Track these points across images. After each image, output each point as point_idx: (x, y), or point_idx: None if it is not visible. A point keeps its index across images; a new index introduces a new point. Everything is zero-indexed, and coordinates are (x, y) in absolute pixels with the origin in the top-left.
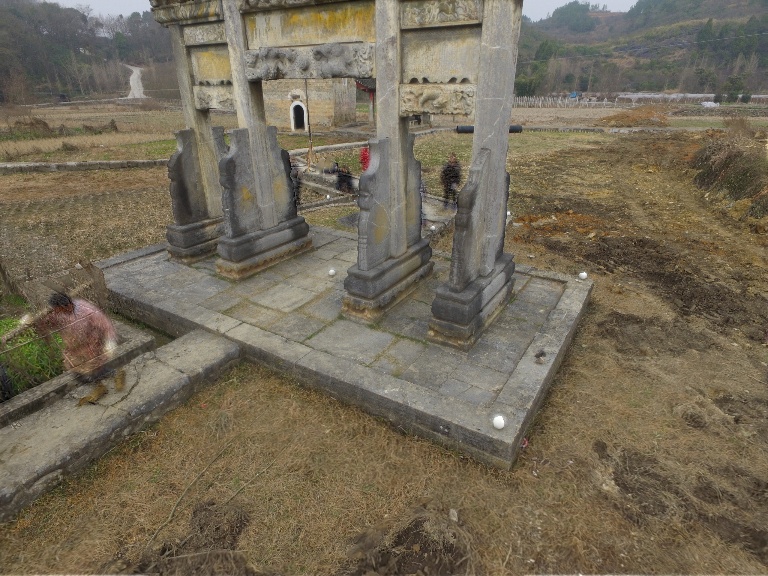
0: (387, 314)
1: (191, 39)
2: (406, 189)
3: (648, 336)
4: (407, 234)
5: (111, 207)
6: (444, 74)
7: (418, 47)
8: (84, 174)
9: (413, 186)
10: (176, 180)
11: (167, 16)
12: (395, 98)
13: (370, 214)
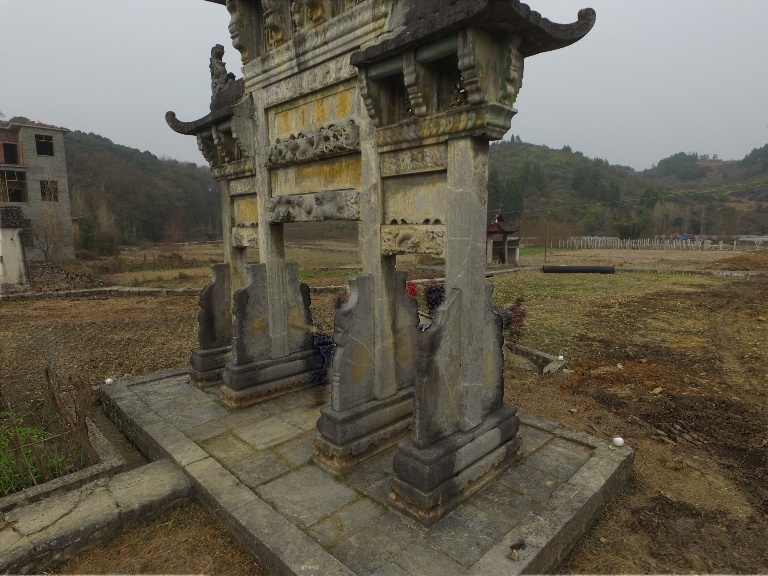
0: (361, 465)
1: (234, 190)
2: (394, 327)
3: (704, 538)
4: (400, 374)
5: (187, 329)
6: (419, 216)
7: (397, 192)
8: (185, 299)
9: (407, 324)
10: (205, 308)
11: (219, 173)
12: (377, 238)
13: (344, 351)
